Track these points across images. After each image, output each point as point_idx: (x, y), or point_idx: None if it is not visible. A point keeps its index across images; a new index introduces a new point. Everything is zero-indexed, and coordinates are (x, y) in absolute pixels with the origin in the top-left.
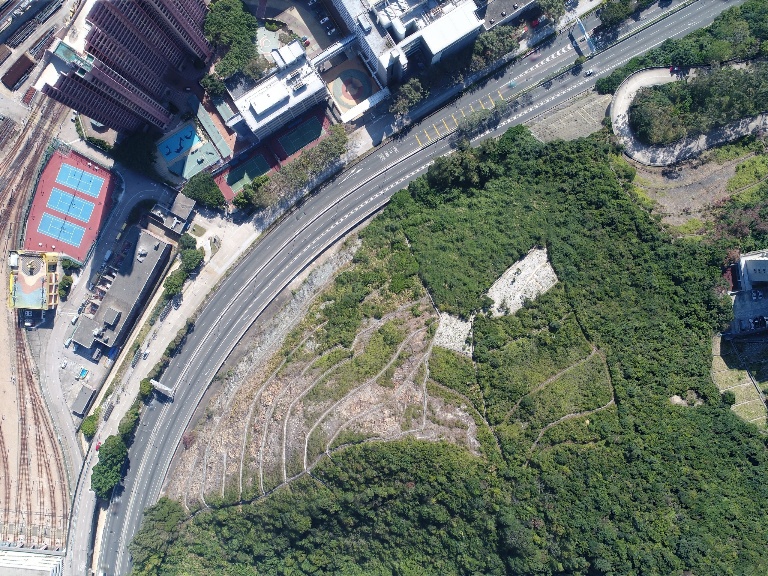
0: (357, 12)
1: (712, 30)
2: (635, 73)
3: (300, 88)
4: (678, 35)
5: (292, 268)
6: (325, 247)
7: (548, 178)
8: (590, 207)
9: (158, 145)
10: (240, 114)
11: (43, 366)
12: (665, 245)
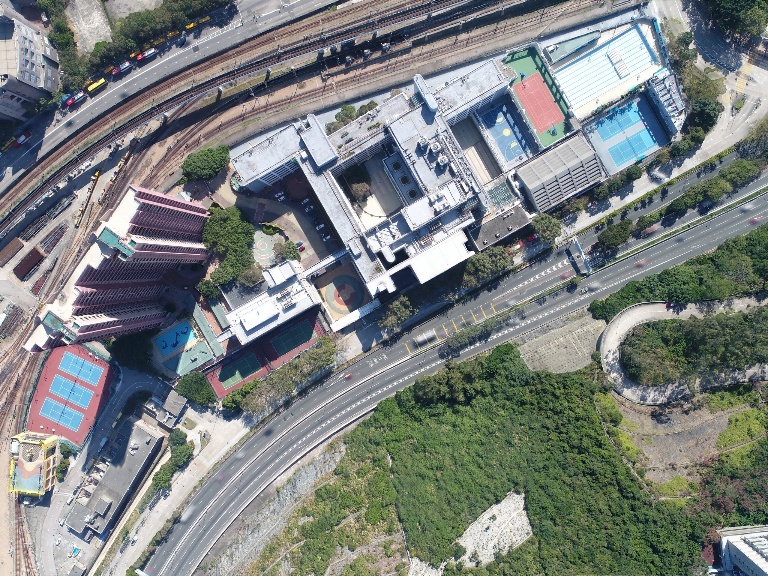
0: (348, 236)
1: (715, 260)
2: (628, 308)
3: (289, 306)
4: (680, 257)
5: (278, 466)
6: (311, 448)
7: (533, 410)
8: (572, 450)
9: (155, 339)
10: (230, 331)
11: (39, 542)
12: (645, 507)
